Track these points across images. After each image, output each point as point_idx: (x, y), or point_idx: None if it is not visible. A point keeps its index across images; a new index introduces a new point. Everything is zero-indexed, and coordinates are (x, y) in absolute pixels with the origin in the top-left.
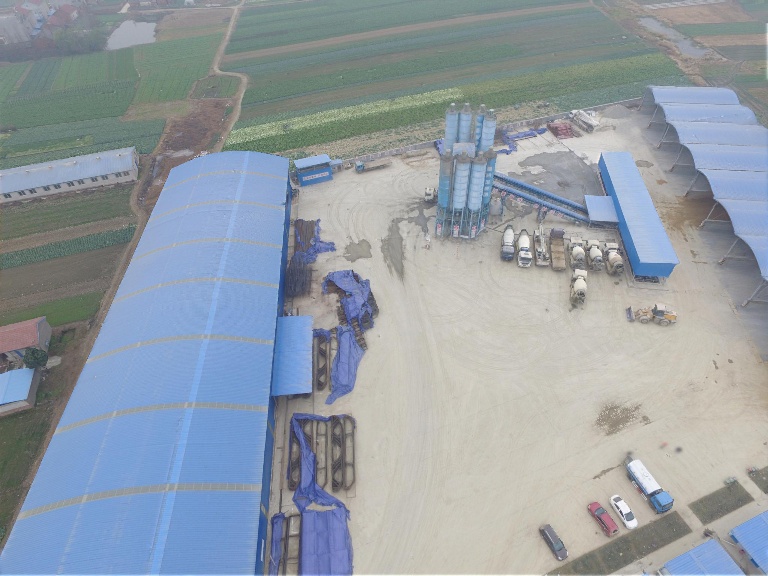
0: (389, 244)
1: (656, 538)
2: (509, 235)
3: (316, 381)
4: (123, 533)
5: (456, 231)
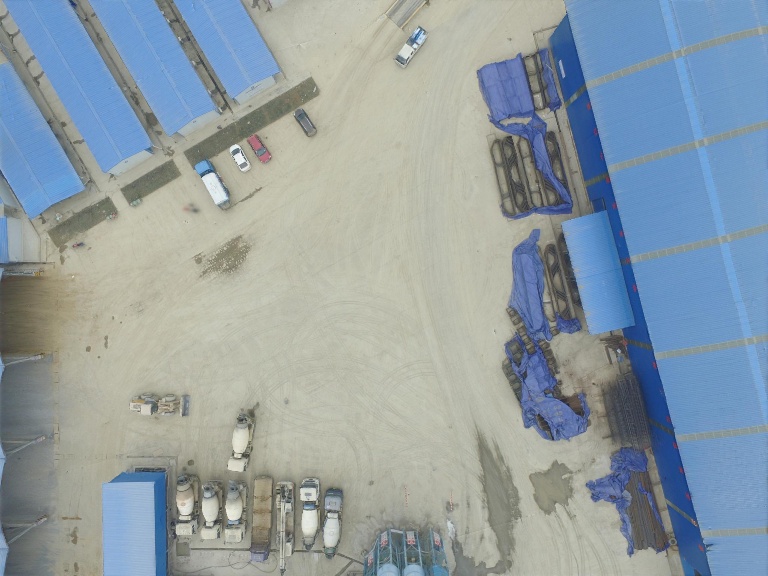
0: (508, 508)
1: (216, 142)
2: (332, 532)
3: (558, 254)
4: (705, 4)
5: (411, 538)
